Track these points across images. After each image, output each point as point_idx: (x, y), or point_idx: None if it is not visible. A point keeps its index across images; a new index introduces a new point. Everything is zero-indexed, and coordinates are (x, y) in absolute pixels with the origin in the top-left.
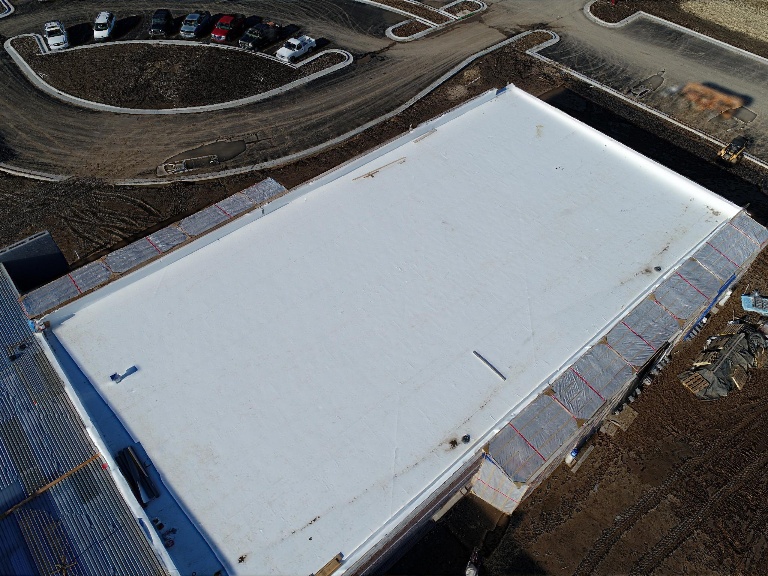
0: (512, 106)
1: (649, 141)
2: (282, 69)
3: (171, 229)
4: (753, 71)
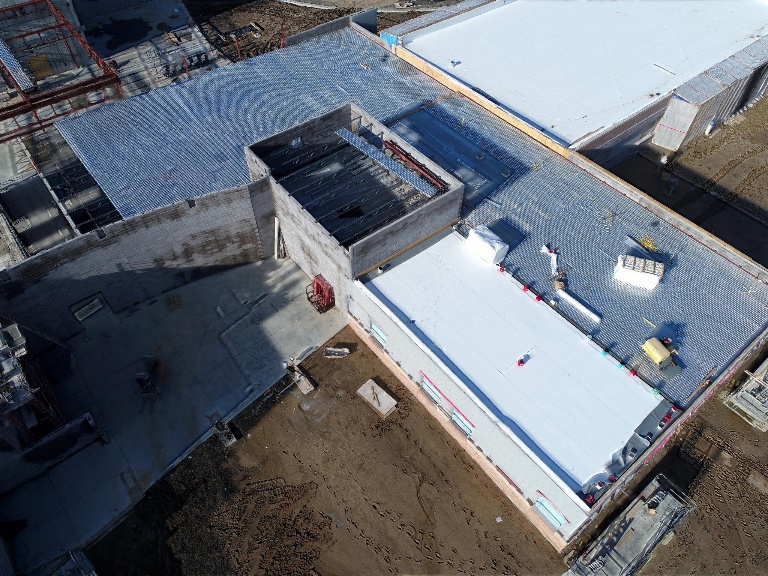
0: None
1: None
2: None
3: (453, 6)
4: None
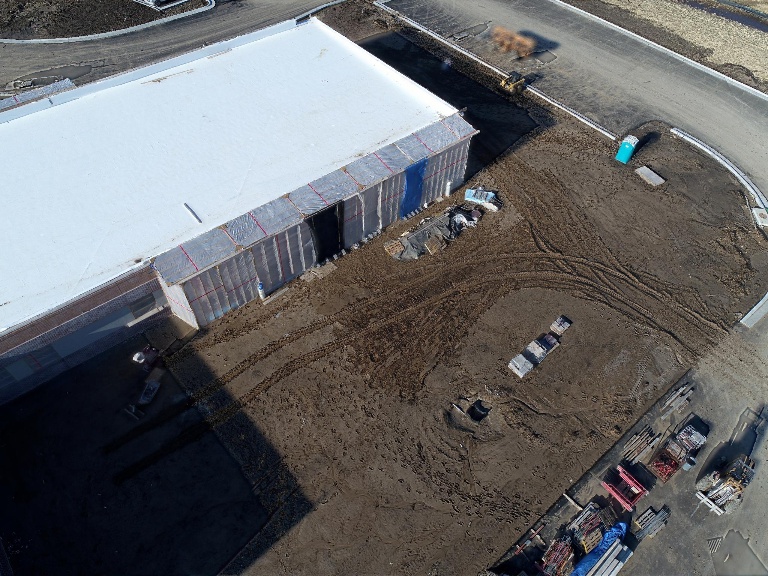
0: (308, 34)
1: (447, 74)
2: (147, 11)
3: None
4: (571, 22)
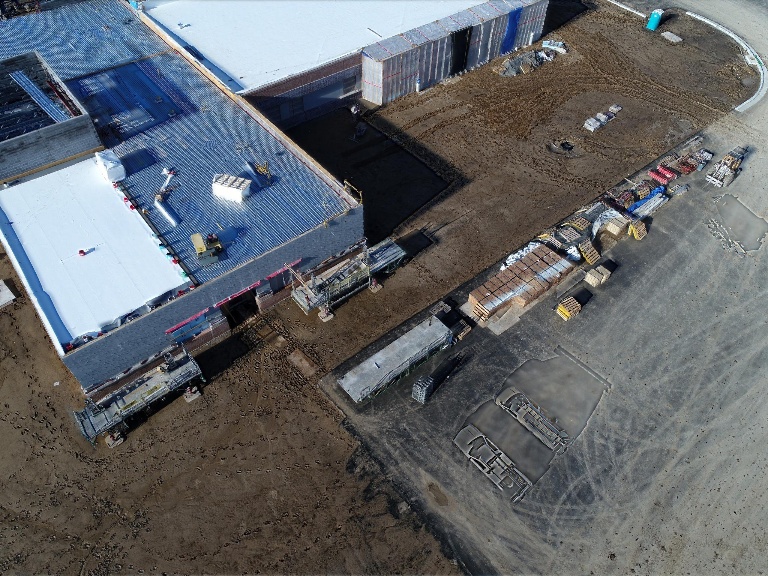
0: None
1: None
2: None
3: None
4: None
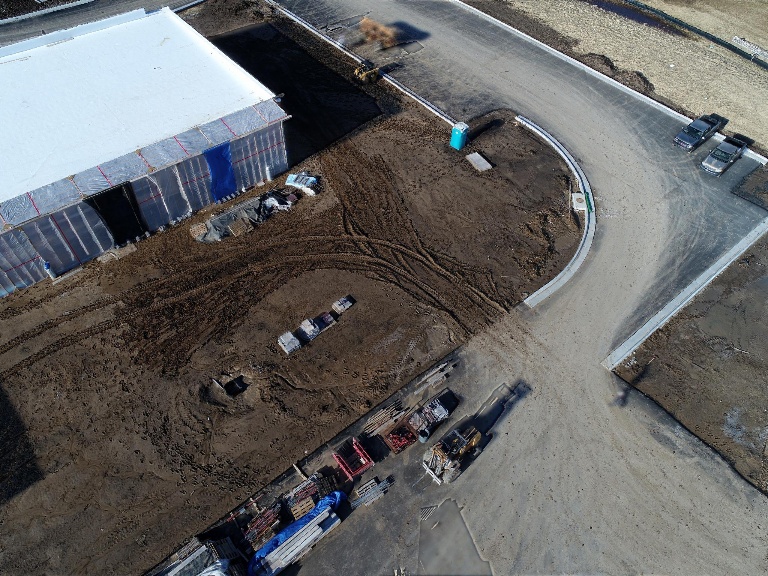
0: (156, 23)
1: (306, 64)
2: (28, 3)
3: None
4: (448, 14)
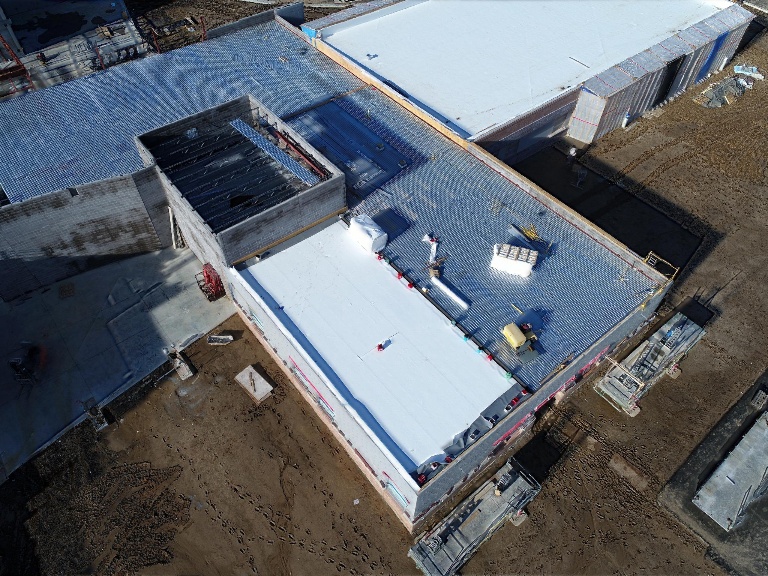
0: None
1: None
2: None
3: (378, 0)
4: None
